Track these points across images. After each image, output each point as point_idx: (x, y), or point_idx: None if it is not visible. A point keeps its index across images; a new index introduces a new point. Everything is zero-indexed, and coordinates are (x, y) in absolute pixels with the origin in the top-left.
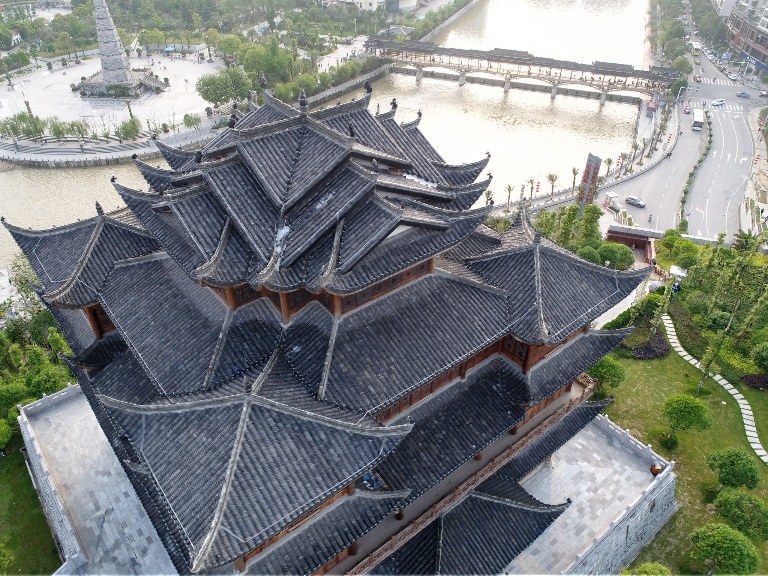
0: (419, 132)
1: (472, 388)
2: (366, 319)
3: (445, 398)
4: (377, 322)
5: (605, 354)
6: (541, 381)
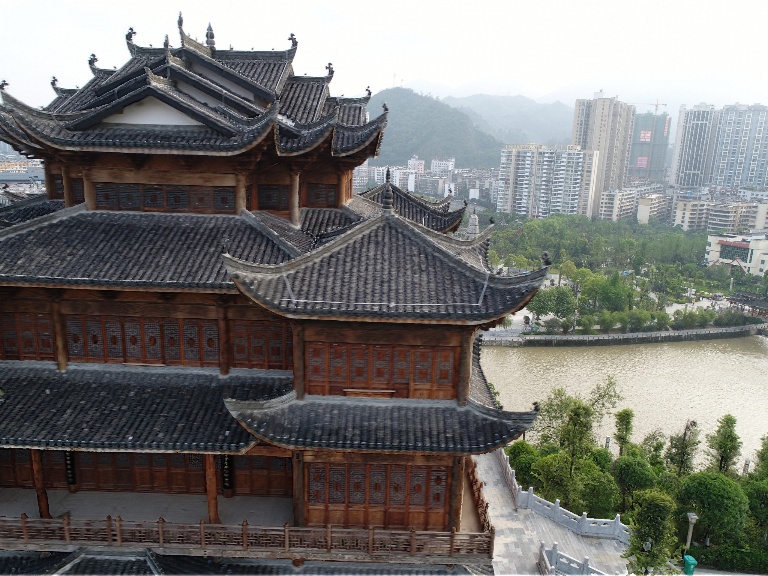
0: (360, 109)
1: (221, 388)
2: (112, 220)
3: (176, 380)
4: (118, 225)
5: (471, 447)
6: (313, 420)
